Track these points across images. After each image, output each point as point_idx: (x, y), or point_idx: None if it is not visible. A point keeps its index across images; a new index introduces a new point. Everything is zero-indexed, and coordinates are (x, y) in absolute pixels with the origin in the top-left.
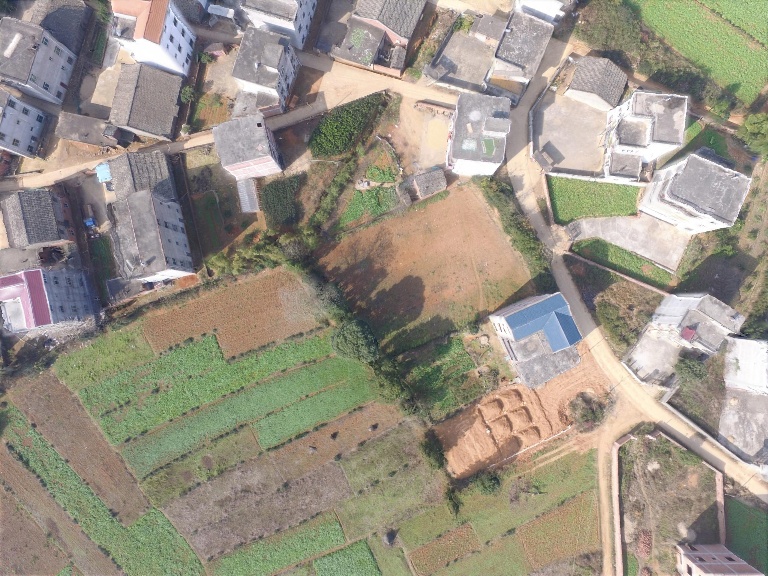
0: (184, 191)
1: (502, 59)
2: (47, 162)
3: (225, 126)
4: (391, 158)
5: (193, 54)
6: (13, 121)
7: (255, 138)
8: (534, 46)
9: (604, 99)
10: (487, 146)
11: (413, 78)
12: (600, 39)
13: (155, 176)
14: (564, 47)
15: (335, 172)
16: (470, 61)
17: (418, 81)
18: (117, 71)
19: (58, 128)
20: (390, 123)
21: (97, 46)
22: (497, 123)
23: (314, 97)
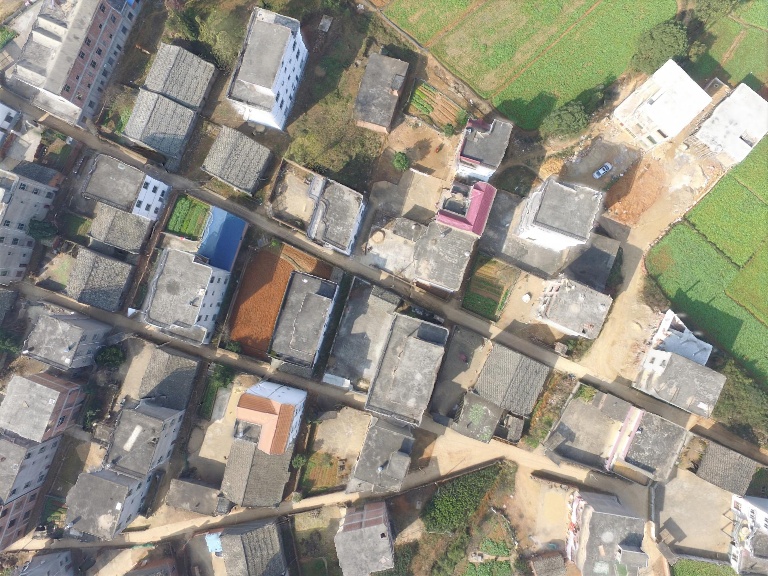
0: (292, 554)
1: (631, 460)
2: (154, 517)
3: (348, 536)
4: (506, 530)
5: (304, 413)
6: (128, 505)
7: (378, 549)
8: (665, 448)
9: (734, 492)
10: (619, 570)
11: (529, 446)
12: (726, 415)
13: (267, 552)
14: (687, 418)
15: (447, 540)
16: (588, 429)
17: (535, 450)
18: (226, 424)
19: (169, 496)
20: (505, 493)
21: (206, 398)
22: (634, 558)
23: (427, 461)
